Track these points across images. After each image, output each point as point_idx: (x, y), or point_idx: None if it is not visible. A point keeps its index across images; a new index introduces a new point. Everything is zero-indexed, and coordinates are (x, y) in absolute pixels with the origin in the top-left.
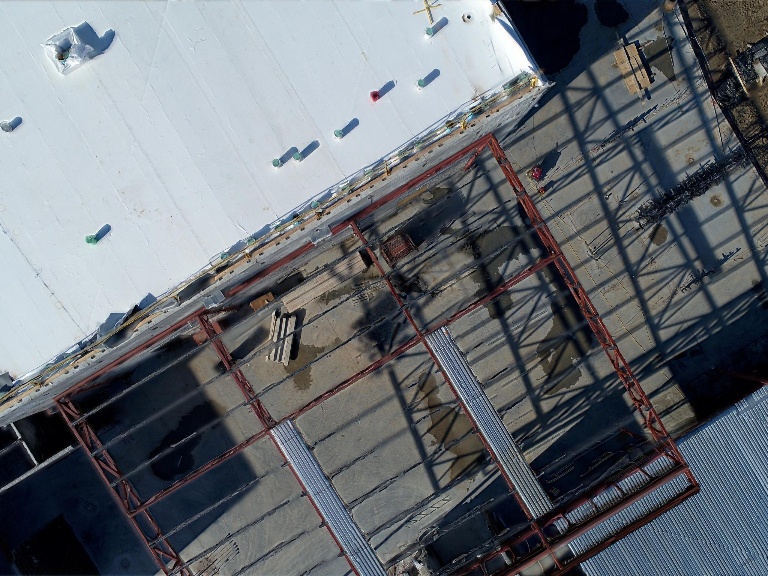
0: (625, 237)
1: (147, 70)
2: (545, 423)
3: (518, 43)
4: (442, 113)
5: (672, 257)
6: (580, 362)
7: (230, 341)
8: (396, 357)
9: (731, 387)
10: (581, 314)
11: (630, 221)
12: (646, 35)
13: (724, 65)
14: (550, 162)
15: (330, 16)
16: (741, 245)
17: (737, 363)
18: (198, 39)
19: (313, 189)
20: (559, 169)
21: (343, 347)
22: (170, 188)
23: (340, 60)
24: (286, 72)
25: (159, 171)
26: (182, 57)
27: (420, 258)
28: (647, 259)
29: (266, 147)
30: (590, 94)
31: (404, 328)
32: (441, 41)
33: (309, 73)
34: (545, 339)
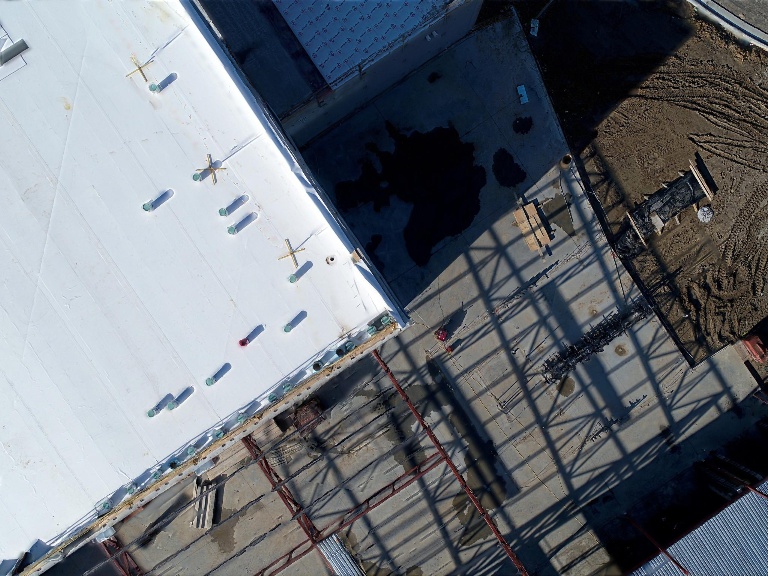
0: (533, 390)
1: (25, 329)
2: (464, 573)
3: (377, 289)
4: (311, 353)
5: (580, 407)
6: (495, 513)
7: (154, 509)
8: (316, 517)
9: (639, 538)
10: (494, 466)
11: (537, 374)
12: (544, 193)
13: (623, 217)
14: (457, 321)
15: (198, 266)
16: (647, 392)
17: (649, 507)
18: (72, 296)
19: (190, 433)
20: (466, 327)
21: (264, 509)
22: (53, 440)
23: (210, 308)
24: (158, 323)
25: (42, 424)
26: (58, 314)
27: (335, 420)
28: (556, 410)
29: (143, 395)
30: (492, 253)
31: (322, 488)
32: (306, 284)
33: (181, 322)
34: (460, 492)
